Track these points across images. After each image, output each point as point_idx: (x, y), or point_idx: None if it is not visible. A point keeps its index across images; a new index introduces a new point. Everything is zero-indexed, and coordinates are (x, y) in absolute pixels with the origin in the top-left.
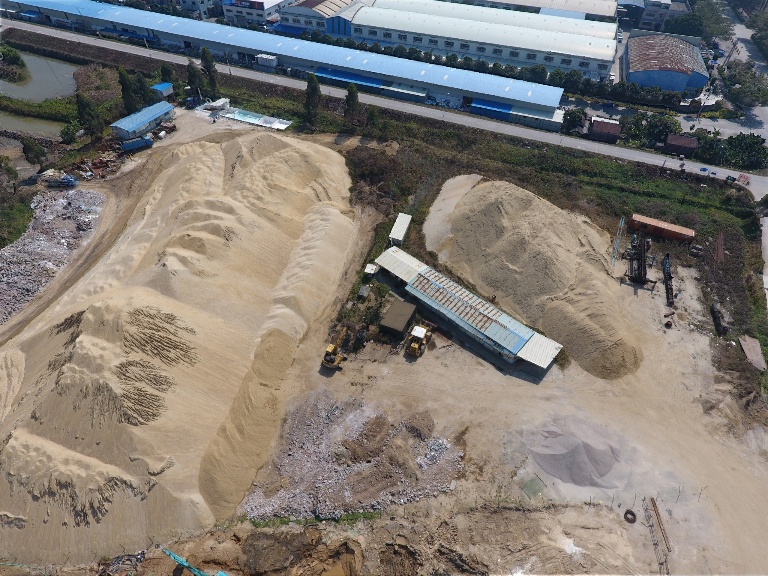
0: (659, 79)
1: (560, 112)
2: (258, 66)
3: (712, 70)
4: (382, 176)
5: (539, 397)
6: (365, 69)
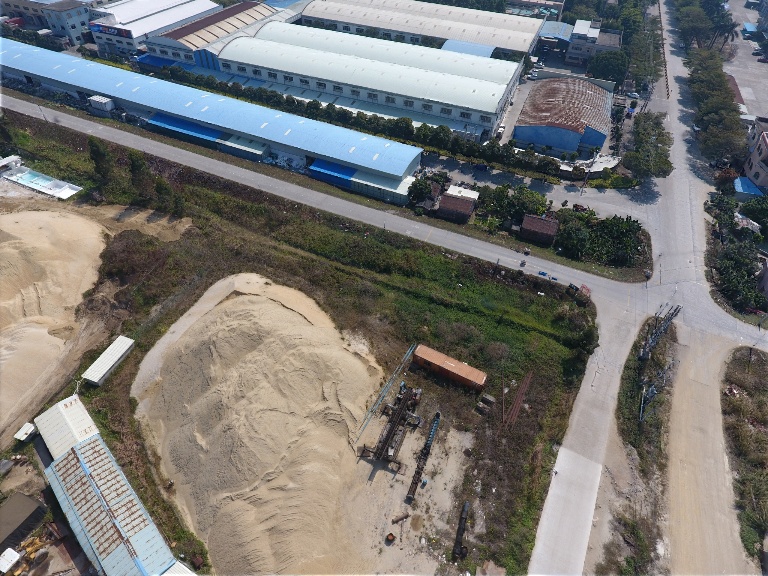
0: (548, 136)
1: (410, 180)
2: (93, 109)
3: (628, 119)
4: (133, 276)
5: None
6: (201, 119)
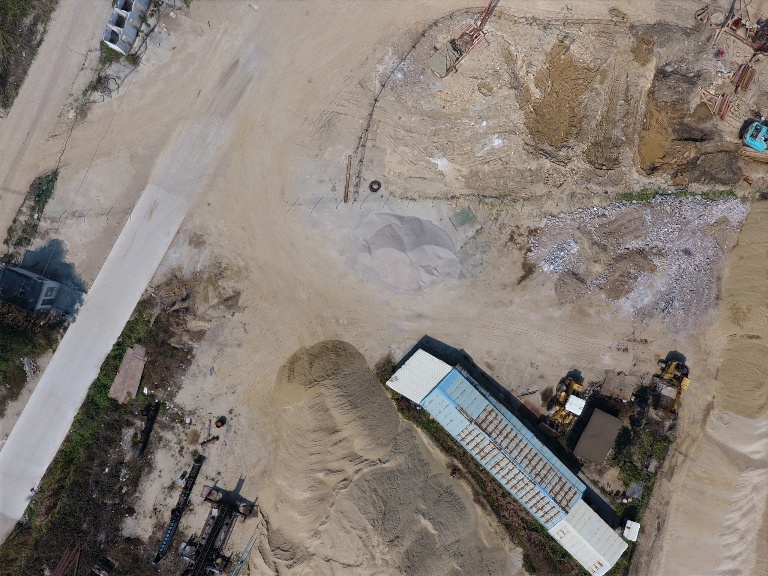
0: None
1: None
2: None
3: None
4: None
5: (429, 318)
6: None
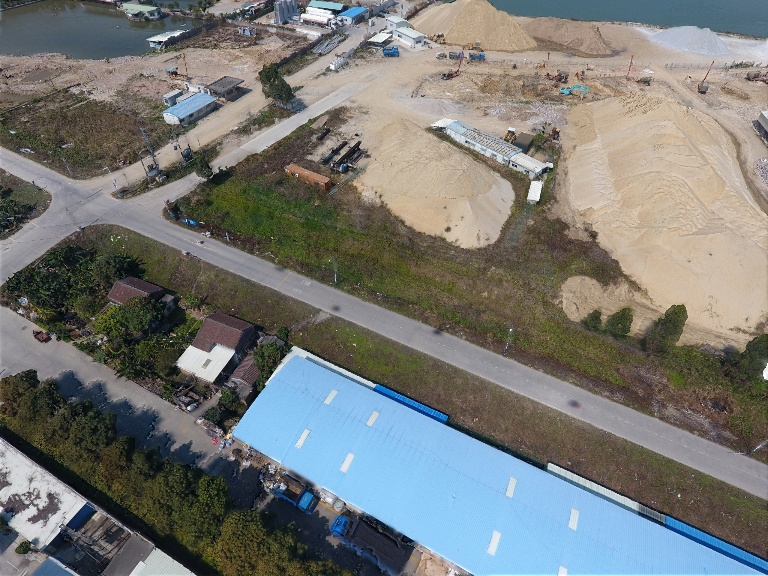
0: None
1: None
2: None
3: None
4: None
5: None
6: (742, 567)
